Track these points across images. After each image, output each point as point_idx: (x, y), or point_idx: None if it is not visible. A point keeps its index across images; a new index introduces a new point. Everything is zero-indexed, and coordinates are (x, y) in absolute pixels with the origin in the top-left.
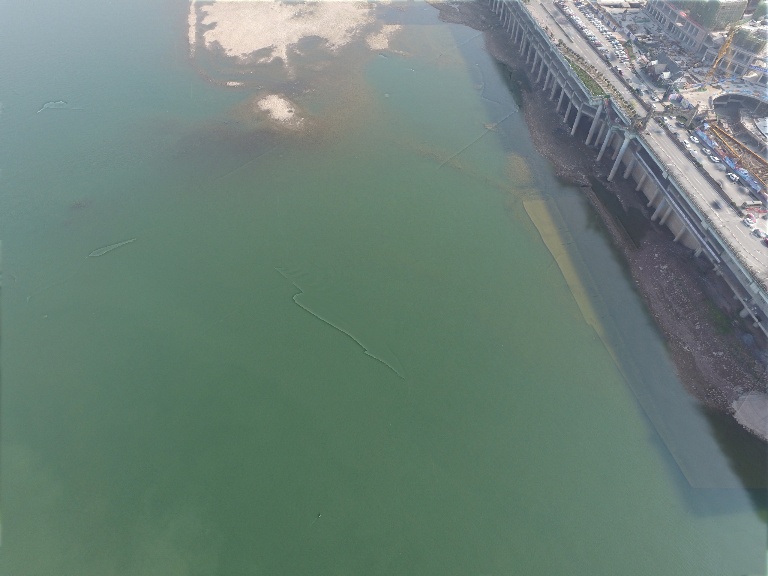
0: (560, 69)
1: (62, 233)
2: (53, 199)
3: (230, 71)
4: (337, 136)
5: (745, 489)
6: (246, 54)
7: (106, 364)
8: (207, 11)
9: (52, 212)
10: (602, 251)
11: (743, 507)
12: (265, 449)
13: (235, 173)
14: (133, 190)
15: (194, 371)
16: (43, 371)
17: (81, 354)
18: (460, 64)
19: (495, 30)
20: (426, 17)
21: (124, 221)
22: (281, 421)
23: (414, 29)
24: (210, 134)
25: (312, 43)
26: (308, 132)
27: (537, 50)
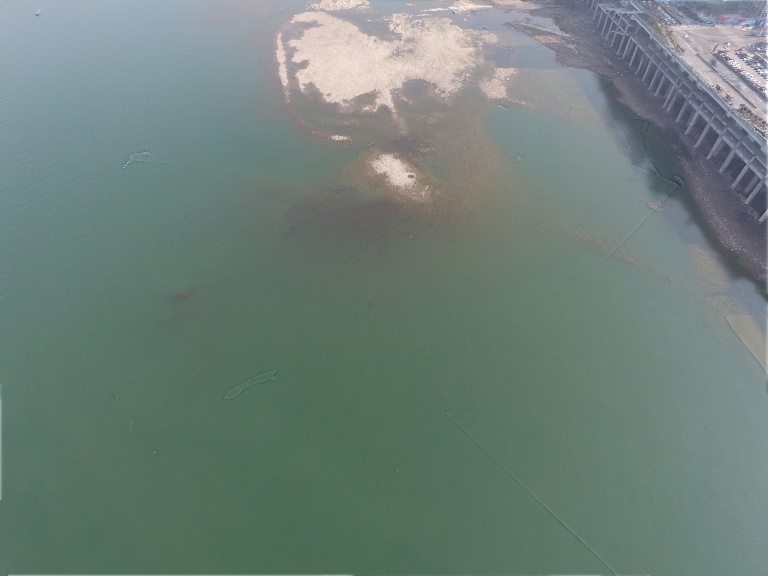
0: (743, 140)
1: (166, 333)
2: (155, 289)
3: (333, 121)
4: (472, 212)
5: None
6: (347, 100)
7: (238, 537)
8: (296, 46)
9: (154, 306)
10: None
11: None
12: None
13: (360, 258)
14: (245, 278)
15: (354, 559)
16: (162, 546)
17: (206, 520)
18: (596, 120)
19: (627, 78)
20: (541, 59)
21: (237, 319)
22: None
23: (531, 74)
24: (323, 203)
25: (419, 88)
26: (437, 205)
27: (698, 110)
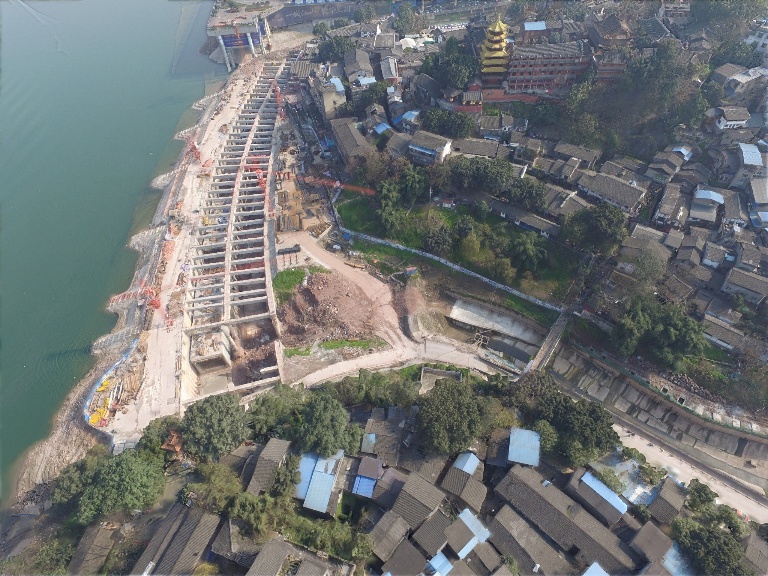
0: None
1: None
2: None
3: None
4: None
5: (193, 72)
6: None
7: None
8: None
9: None
10: (206, 19)
11: (187, 76)
12: (3, 78)
13: (38, 3)
14: None
15: None
16: None
17: None
18: None
19: None
20: None
21: None
22: (14, 71)
23: None
24: None
25: None
26: None
27: None
